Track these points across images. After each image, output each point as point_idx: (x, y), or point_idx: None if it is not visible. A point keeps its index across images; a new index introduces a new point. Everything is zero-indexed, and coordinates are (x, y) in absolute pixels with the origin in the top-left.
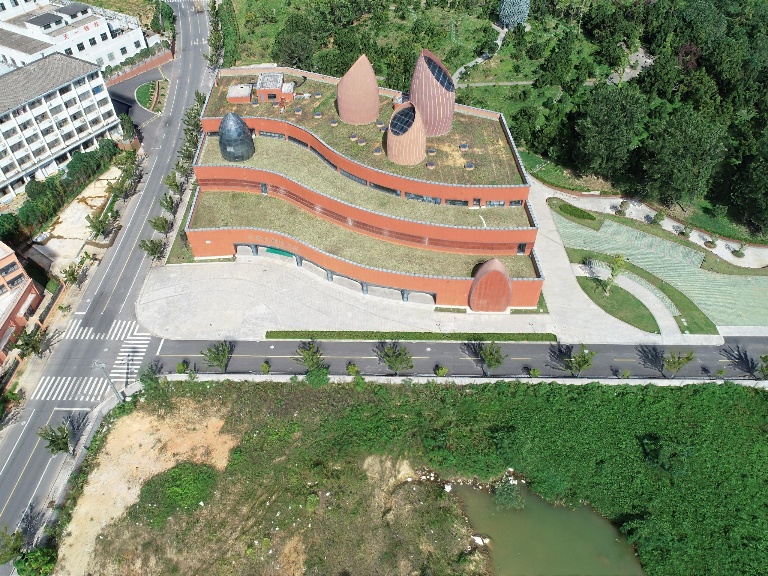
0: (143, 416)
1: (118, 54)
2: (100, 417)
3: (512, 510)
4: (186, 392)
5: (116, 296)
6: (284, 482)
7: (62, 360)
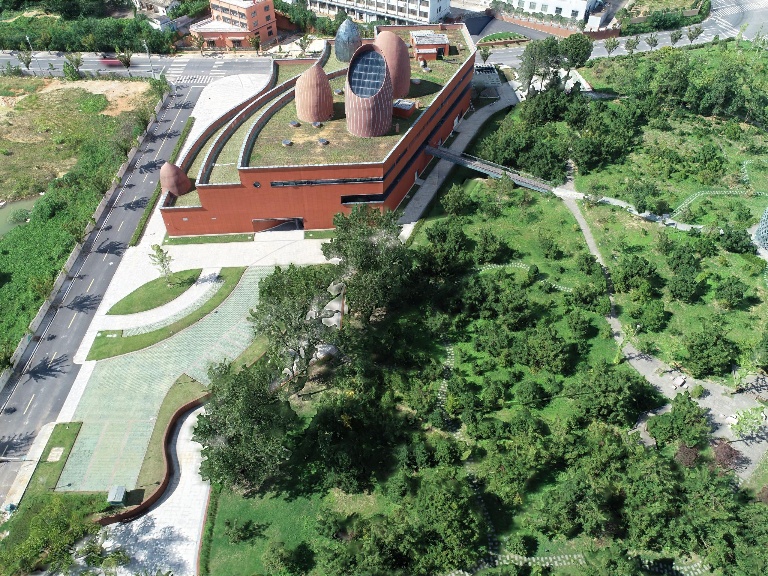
0: (147, 88)
1: (552, 10)
2: (149, 75)
3: (8, 215)
4: (157, 97)
5: (248, 67)
6: (78, 133)
7: (200, 61)
